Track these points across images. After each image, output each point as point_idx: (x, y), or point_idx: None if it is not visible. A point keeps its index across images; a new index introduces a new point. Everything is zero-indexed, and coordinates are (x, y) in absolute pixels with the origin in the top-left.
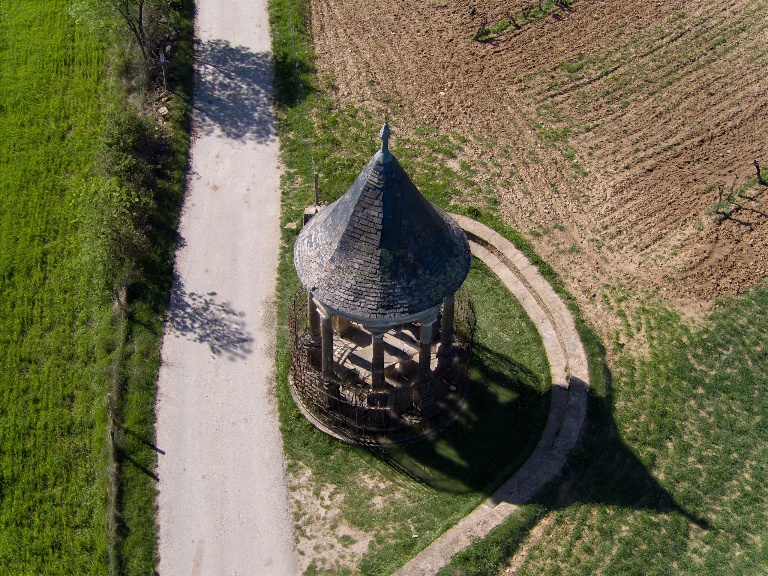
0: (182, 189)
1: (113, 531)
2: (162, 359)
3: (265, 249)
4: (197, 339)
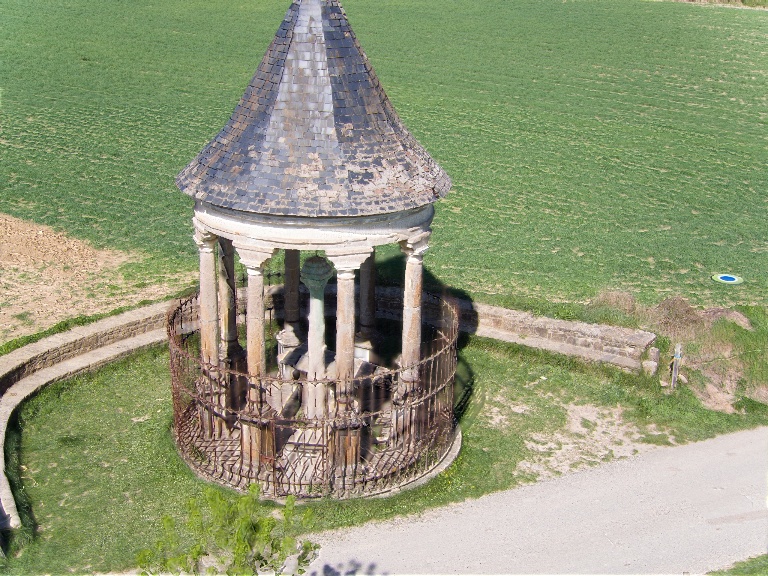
0: None
1: None
2: None
3: None
4: None
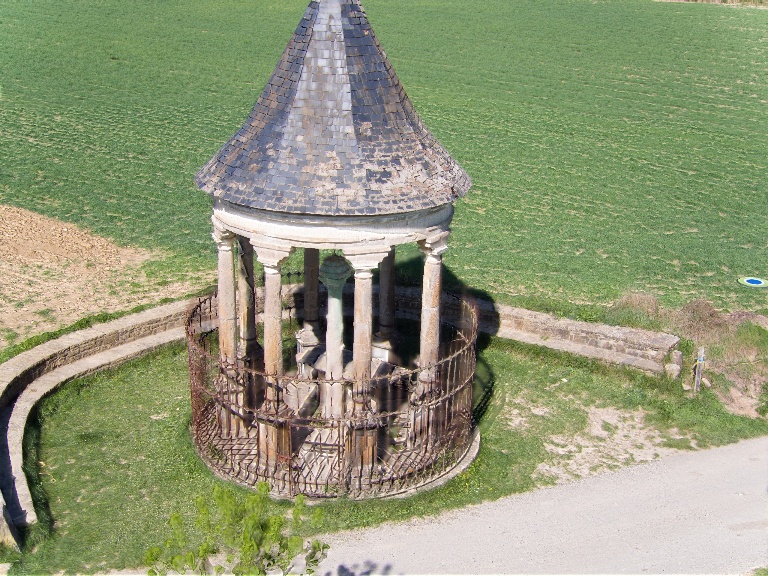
0: None
1: None
2: None
3: None
4: None
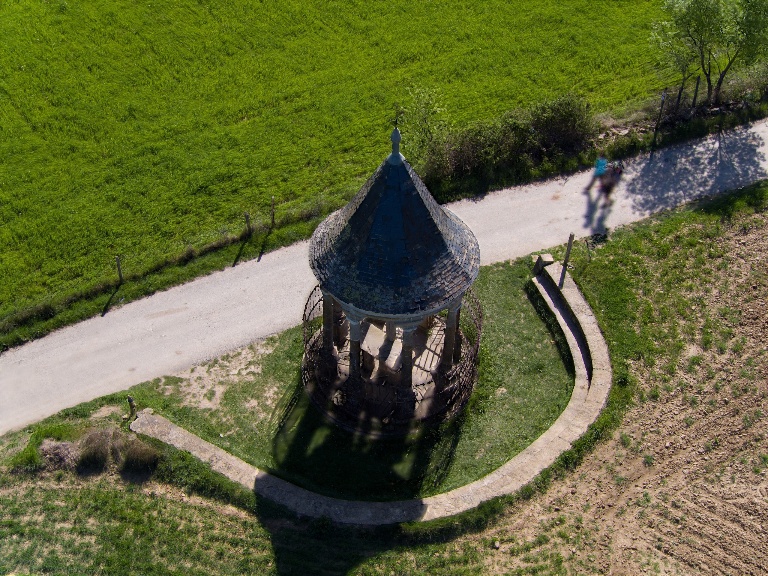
0: (540, 178)
1: (179, 255)
2: None
3: (499, 251)
4: None
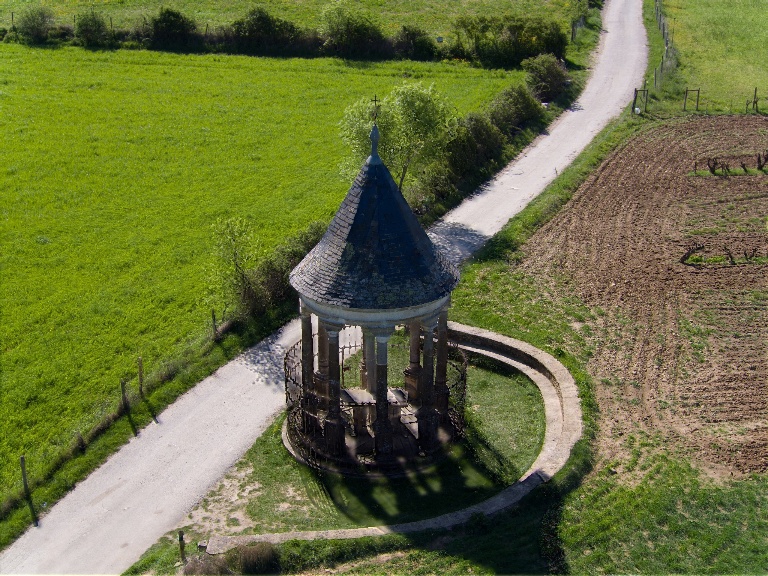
0: None
1: (71, 448)
2: (216, 372)
3: None
4: (254, 369)
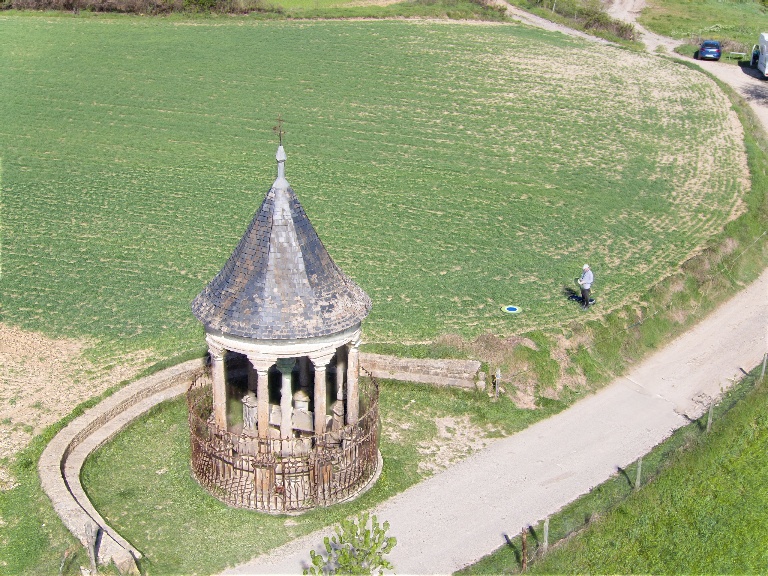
0: None
1: (601, 516)
2: None
3: None
4: None
